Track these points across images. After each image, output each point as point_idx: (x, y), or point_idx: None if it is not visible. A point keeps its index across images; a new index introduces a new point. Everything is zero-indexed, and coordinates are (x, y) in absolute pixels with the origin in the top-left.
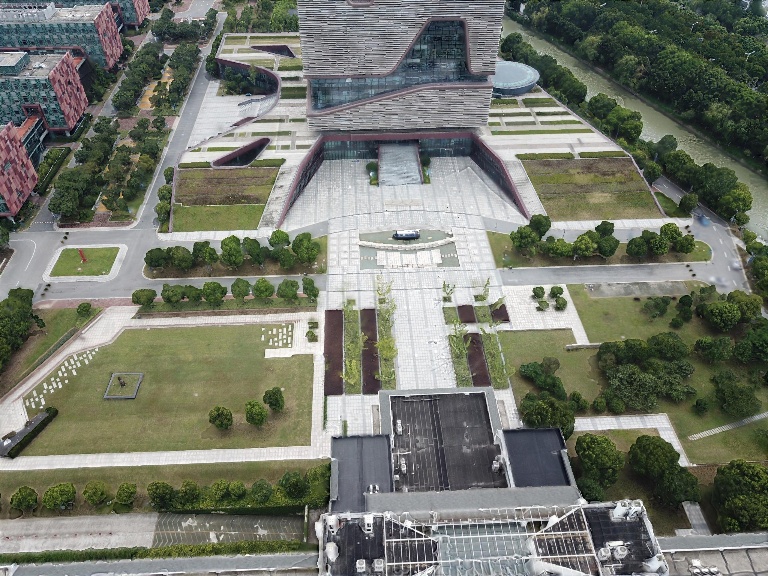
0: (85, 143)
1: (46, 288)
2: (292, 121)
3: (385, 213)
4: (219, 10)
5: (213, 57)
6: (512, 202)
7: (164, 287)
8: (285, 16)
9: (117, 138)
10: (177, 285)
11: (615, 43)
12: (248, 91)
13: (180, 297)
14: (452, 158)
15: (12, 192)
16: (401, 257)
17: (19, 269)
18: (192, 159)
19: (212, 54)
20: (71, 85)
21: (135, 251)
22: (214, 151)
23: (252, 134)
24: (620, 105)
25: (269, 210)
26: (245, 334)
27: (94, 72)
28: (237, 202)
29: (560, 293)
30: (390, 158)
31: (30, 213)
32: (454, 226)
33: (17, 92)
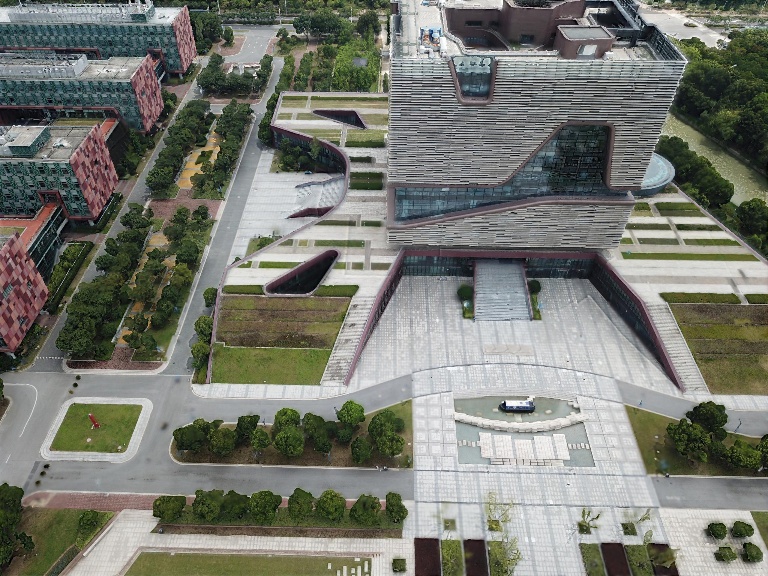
0: (109, 245)
1: (43, 471)
2: (365, 224)
3: (486, 366)
4: (274, 54)
5: (268, 123)
6: (653, 357)
7: (197, 496)
8: (350, 66)
9: (149, 231)
10: (214, 493)
11: (759, 122)
12: (307, 167)
13: (218, 513)
14: (566, 280)
15: (12, 323)
16: (513, 445)
17: (12, 434)
18: (240, 279)
19: (266, 119)
20: (98, 164)
21: (162, 412)
22: (268, 268)
23: (315, 243)
24: (767, 204)
25: (336, 358)
26: (304, 574)
27: (128, 136)
28: (295, 344)
29: (750, 535)
30: (489, 281)
31: (35, 342)
32: (580, 394)
33: (32, 176)
